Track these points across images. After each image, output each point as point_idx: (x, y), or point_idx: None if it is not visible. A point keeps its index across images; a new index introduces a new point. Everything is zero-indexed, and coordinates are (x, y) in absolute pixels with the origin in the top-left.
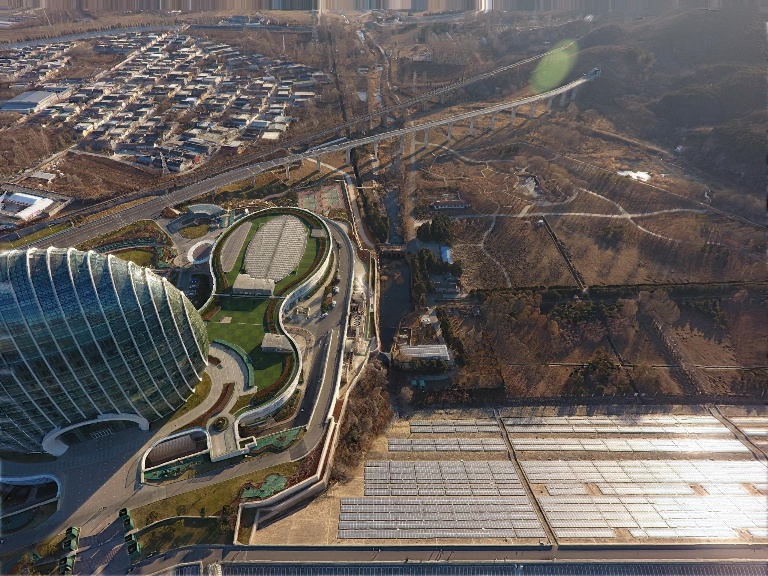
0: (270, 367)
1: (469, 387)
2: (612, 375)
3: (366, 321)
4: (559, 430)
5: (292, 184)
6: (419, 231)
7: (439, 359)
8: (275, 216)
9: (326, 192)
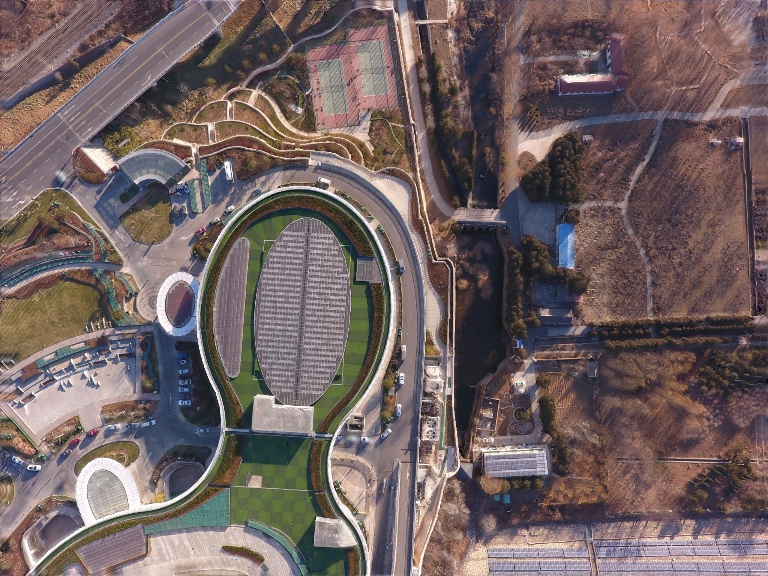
0: (329, 568)
1: (563, 498)
2: (743, 487)
3: (441, 413)
4: (656, 567)
5: (292, 19)
6: (528, 186)
7: (535, 479)
8: (286, 217)
9: (361, 51)
